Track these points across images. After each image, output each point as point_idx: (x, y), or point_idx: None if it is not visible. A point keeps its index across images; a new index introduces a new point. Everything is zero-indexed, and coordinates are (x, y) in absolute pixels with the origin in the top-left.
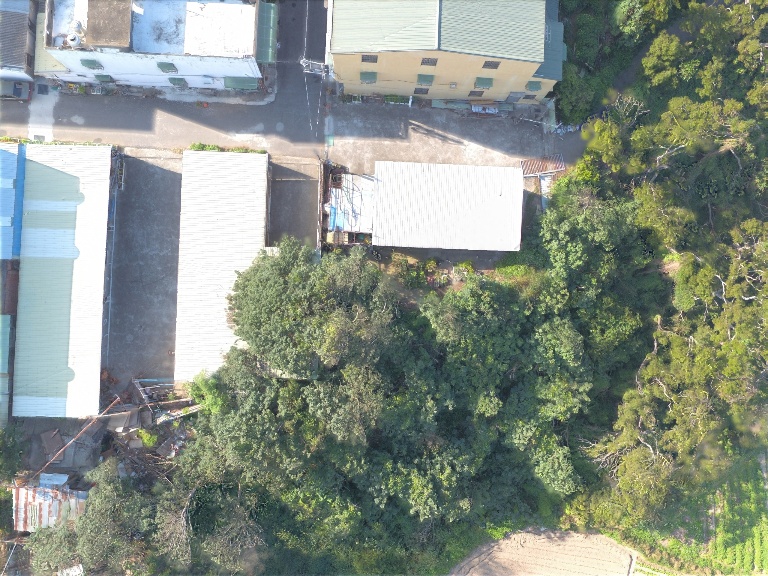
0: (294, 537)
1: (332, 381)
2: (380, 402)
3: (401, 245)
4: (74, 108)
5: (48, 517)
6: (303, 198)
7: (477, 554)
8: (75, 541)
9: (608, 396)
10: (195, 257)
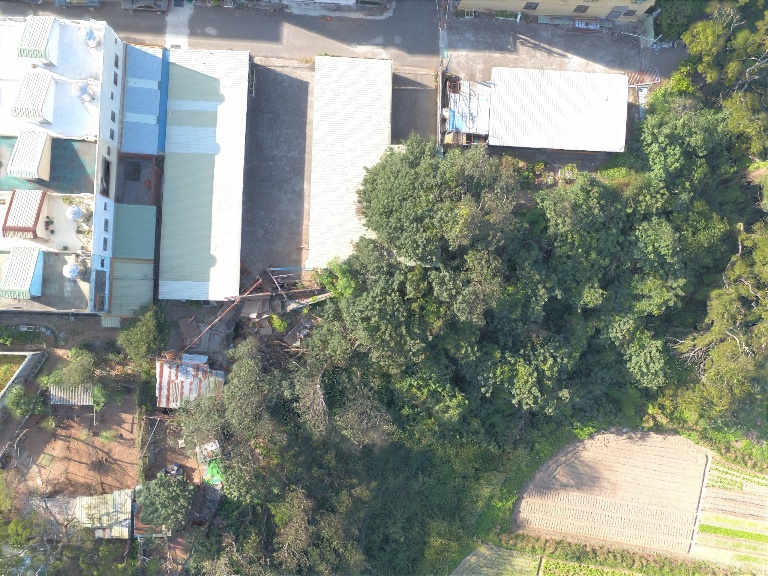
0: (399, 431)
1: (453, 269)
2: None
3: (516, 145)
4: (208, 20)
5: (189, 395)
6: (420, 105)
7: (564, 453)
8: (224, 409)
9: (690, 302)
10: (327, 154)
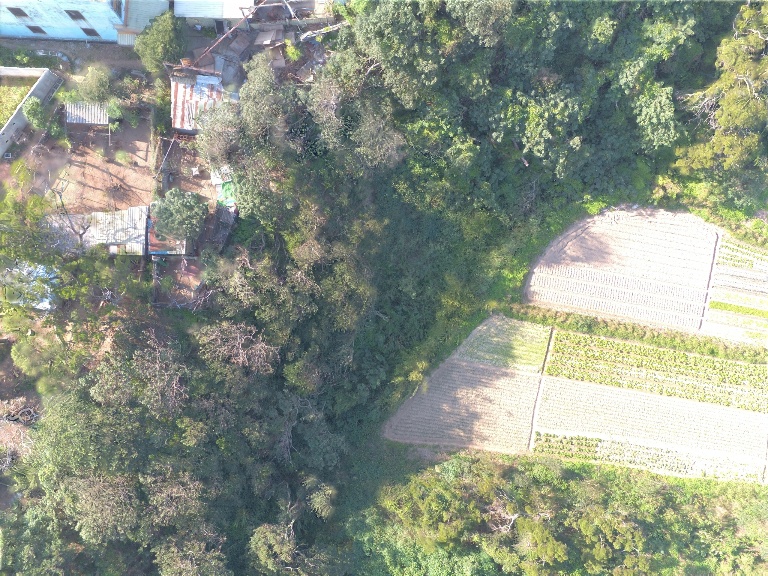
0: (410, 191)
1: None
2: (510, 6)
3: None
4: None
5: None
6: None
7: (574, 229)
8: (238, 110)
9: (699, 69)
10: None
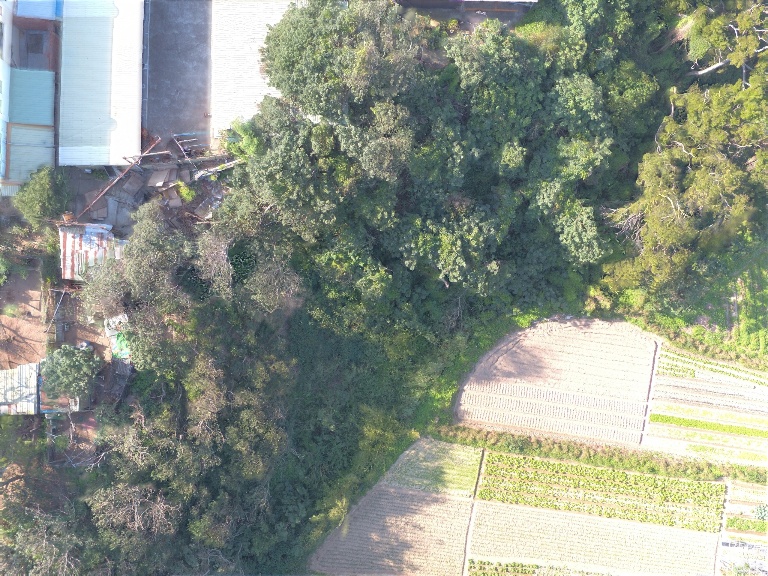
0: (327, 317)
1: (362, 127)
2: None
3: None
4: None
5: None
6: None
7: (505, 343)
8: (122, 269)
9: (628, 176)
10: (228, 13)
